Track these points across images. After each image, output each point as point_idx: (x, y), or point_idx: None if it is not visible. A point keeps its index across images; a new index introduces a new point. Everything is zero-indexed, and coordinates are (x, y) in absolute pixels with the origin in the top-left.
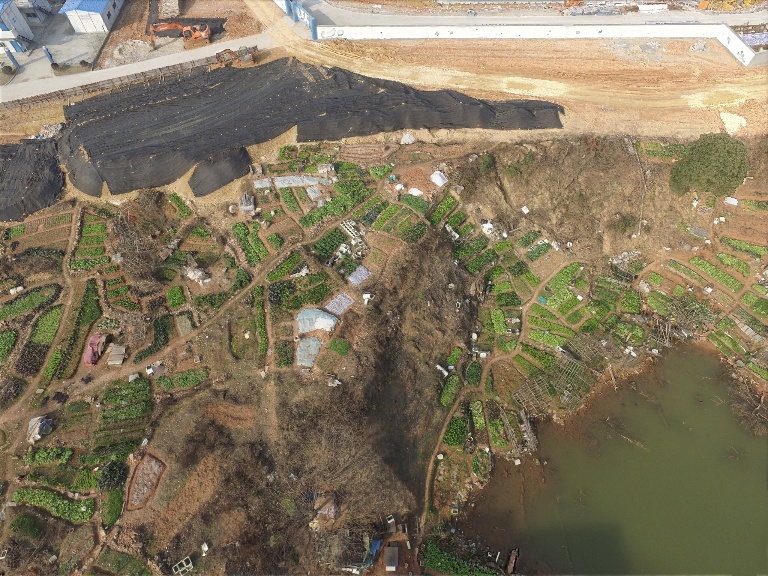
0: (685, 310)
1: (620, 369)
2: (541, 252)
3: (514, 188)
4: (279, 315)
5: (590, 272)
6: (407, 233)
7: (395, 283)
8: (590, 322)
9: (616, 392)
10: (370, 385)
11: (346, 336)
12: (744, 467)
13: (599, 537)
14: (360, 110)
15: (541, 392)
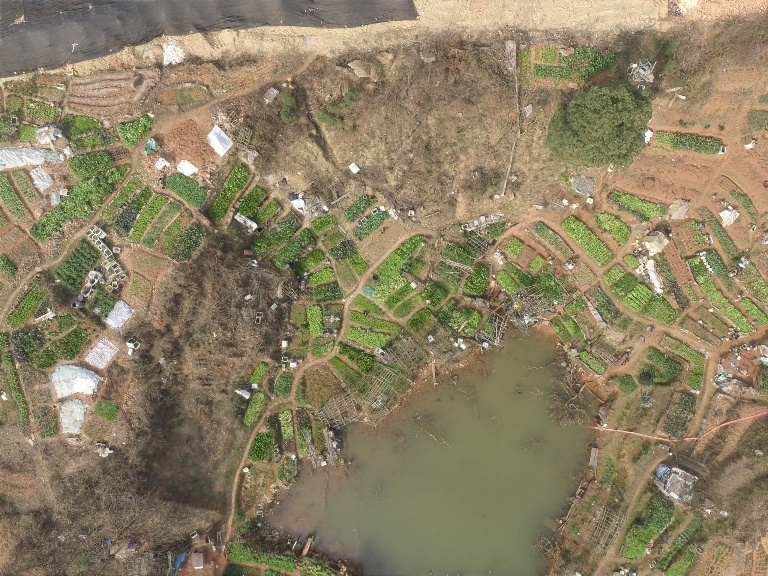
0: (531, 297)
1: (443, 365)
2: (373, 227)
3: (336, 138)
4: (30, 377)
5: (435, 245)
6: (176, 245)
7: (165, 321)
8: (421, 314)
9: (435, 388)
10: (147, 446)
11: (112, 397)
12: (537, 456)
13: (389, 518)
14: (79, 5)
15: (347, 408)
